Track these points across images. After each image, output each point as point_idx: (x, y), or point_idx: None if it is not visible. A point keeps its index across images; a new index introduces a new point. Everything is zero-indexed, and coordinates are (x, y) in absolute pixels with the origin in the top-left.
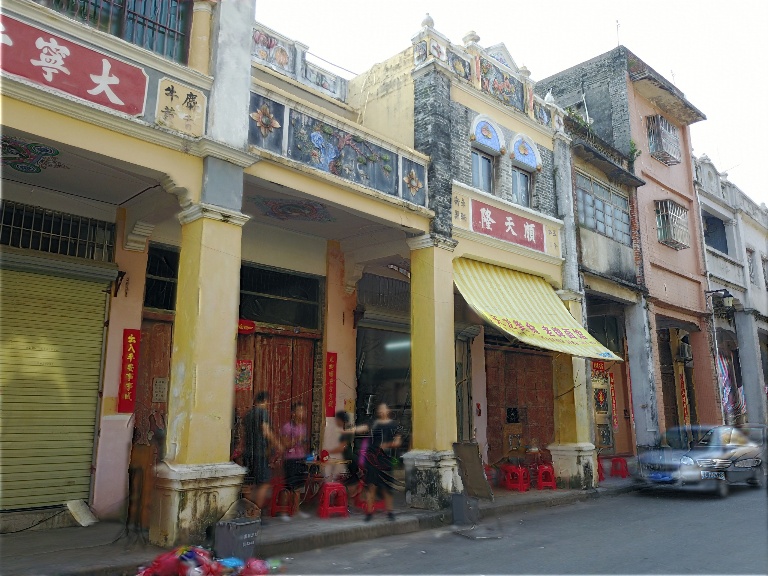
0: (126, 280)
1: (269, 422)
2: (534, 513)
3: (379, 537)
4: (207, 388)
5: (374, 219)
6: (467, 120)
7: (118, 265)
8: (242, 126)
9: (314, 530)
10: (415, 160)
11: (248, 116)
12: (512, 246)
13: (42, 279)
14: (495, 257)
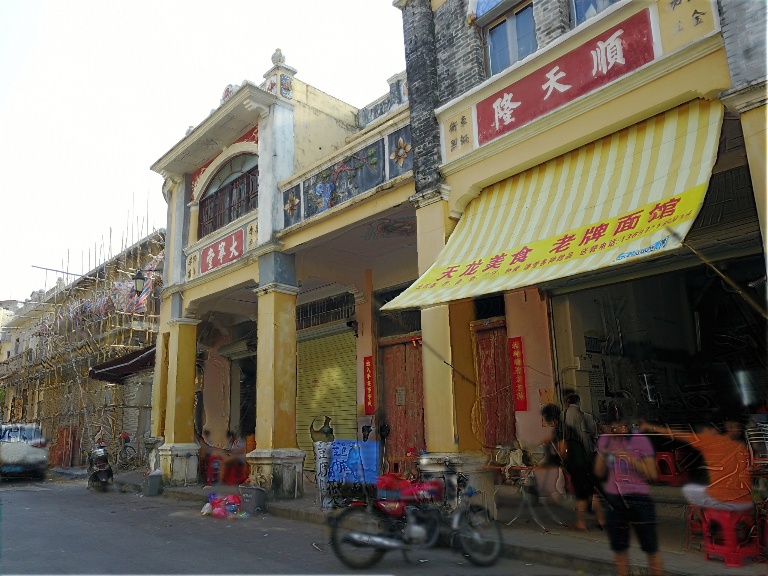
0: (362, 324)
1: (478, 418)
2: (527, 568)
3: (338, 527)
4: (261, 402)
5: (380, 216)
6: (463, 5)
7: (348, 318)
8: (269, 225)
9: (310, 507)
10: (402, 126)
11: (274, 215)
12: (551, 117)
13: (337, 337)
14: (528, 155)
